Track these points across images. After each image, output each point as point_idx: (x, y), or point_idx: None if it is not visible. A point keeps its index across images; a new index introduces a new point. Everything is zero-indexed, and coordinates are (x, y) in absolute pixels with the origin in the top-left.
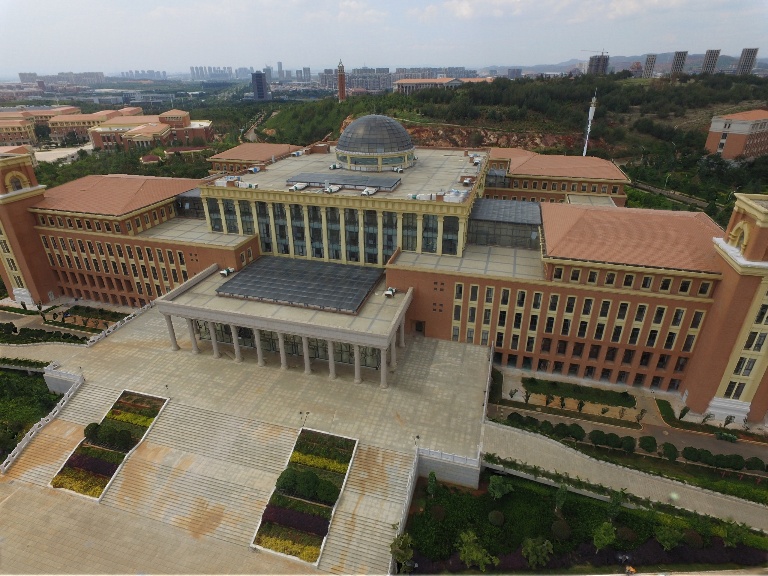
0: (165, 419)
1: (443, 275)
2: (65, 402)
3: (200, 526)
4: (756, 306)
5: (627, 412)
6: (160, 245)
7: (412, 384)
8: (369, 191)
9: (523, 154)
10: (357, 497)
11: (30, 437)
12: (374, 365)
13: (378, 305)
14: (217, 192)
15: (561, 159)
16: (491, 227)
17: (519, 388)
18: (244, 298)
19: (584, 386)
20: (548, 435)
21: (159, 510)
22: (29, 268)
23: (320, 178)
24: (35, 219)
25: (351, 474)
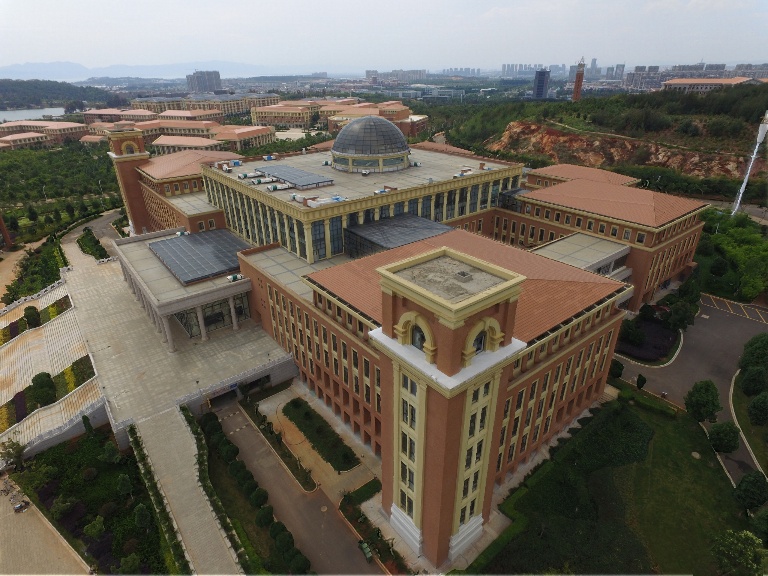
0: (61, 319)
1: (260, 273)
2: (48, 291)
3: (1, 385)
4: (396, 397)
5: (326, 472)
6: (168, 205)
7: (190, 358)
8: (279, 186)
9: (601, 177)
10: (57, 411)
11: (18, 304)
12: (194, 334)
13: (212, 284)
14: (206, 171)
15: (601, 187)
16: (358, 241)
17: (281, 404)
18: (155, 254)
19: (334, 431)
20: (204, 442)
21: (2, 368)
22: (130, 208)
23: (278, 170)
24: (140, 175)
25: (72, 395)
